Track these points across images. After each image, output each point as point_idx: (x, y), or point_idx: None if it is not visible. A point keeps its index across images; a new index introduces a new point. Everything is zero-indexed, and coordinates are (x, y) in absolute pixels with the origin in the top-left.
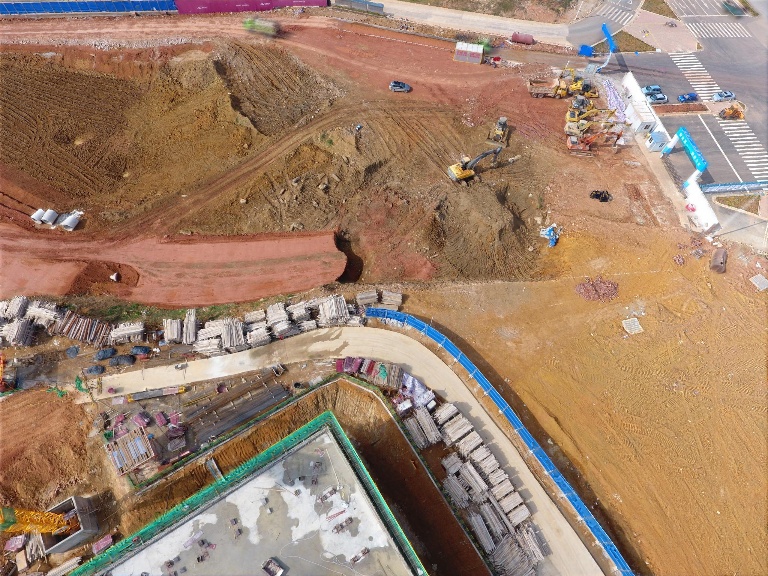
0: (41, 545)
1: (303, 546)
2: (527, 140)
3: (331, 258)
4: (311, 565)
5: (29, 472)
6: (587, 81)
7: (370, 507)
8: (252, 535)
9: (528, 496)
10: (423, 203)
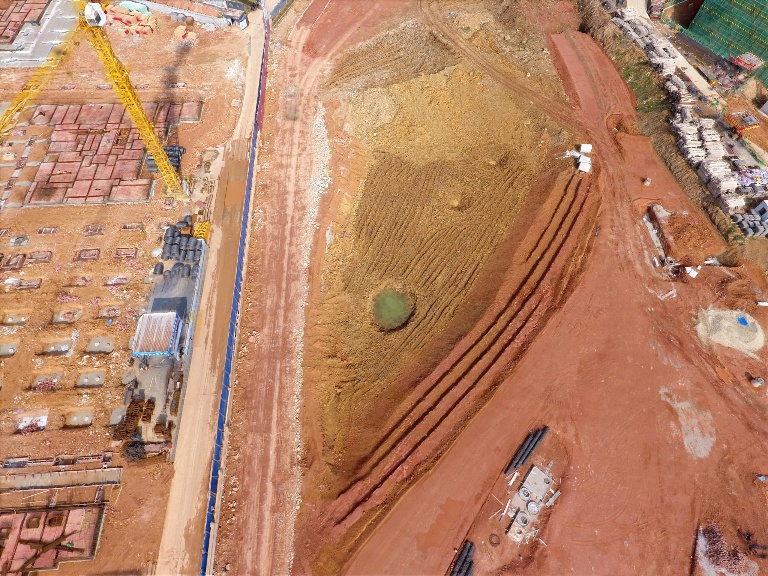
0: None
1: None
2: None
3: (570, 35)
4: None
5: None
6: None
7: None
8: None
9: None
10: None
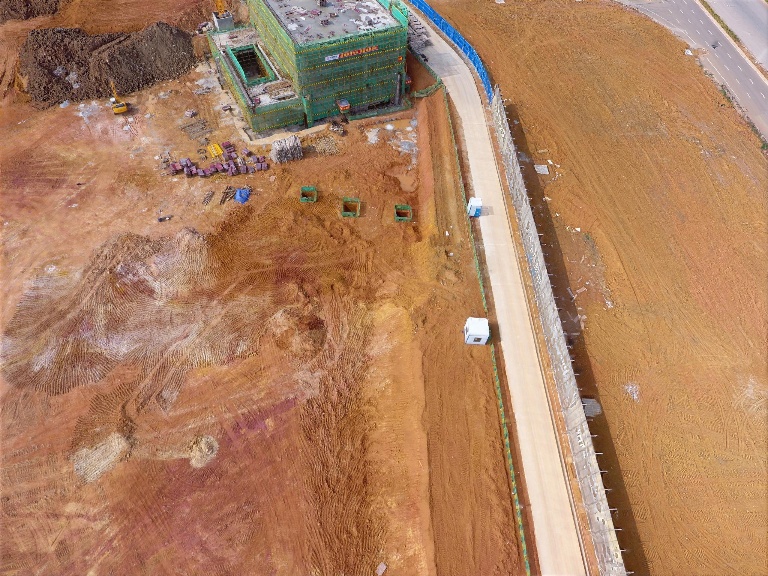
0: None
1: None
2: None
3: None
4: None
5: (208, 7)
6: None
7: None
8: None
9: (428, 33)
10: None
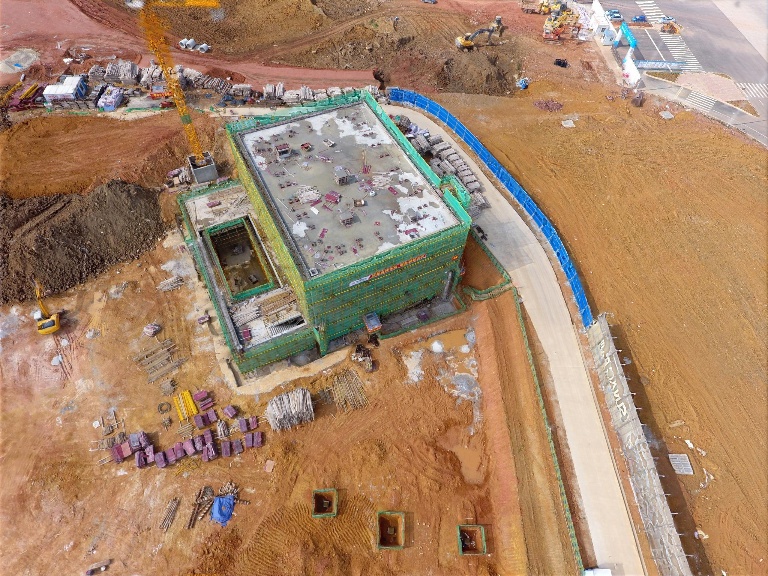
0: (187, 176)
1: (345, 139)
2: (515, 34)
3: (370, 82)
4: (349, 145)
5: (182, 144)
6: (564, 2)
7: (383, 130)
8: (318, 132)
9: (481, 184)
10: (436, 59)
